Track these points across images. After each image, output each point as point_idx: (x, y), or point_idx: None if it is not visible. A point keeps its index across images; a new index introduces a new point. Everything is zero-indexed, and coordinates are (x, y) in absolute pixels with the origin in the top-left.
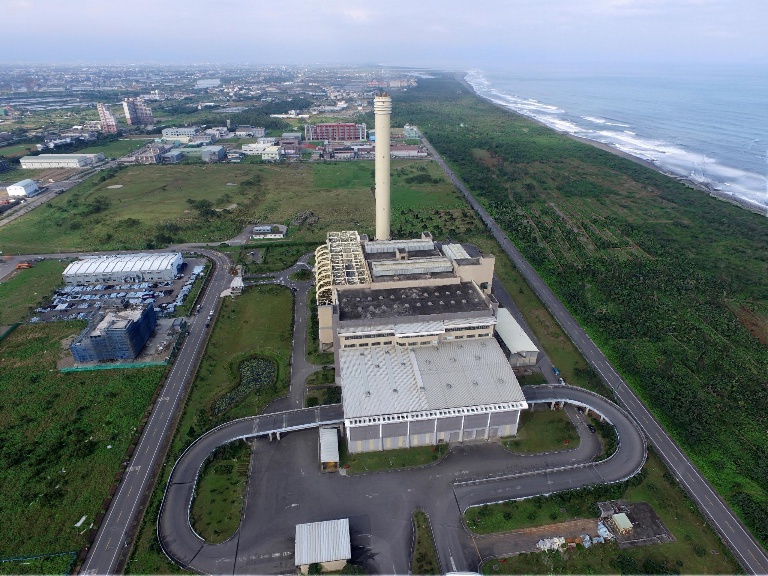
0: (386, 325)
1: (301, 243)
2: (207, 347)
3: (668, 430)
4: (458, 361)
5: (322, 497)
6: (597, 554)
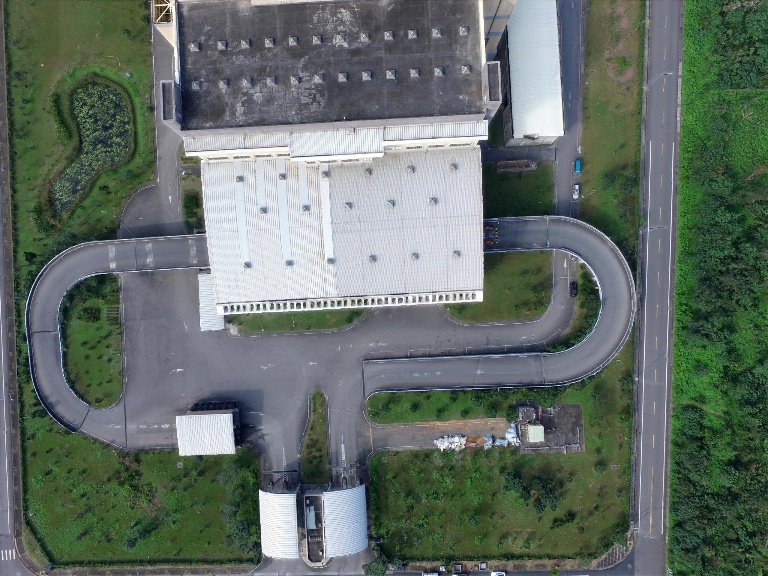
0: (274, 134)
1: None
2: (7, 45)
3: (677, 302)
4: (399, 206)
5: (210, 363)
6: (493, 457)
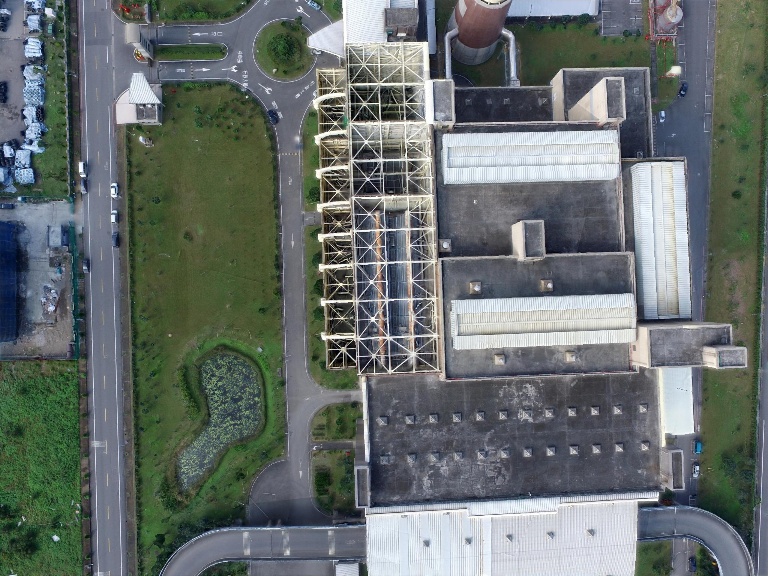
0: None
1: None
2: (133, 314)
3: None
4: (558, 538)
5: None
6: None
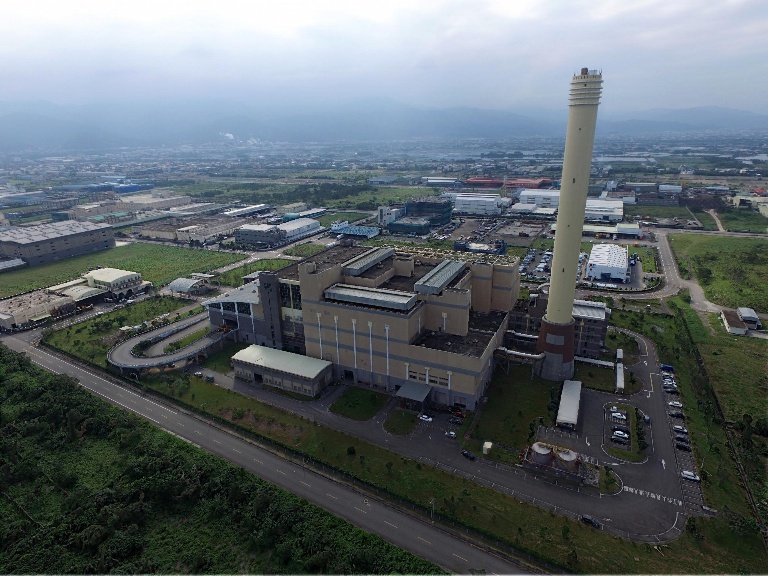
0: None
1: (685, 334)
2: None
3: None
4: None
5: None
6: None
